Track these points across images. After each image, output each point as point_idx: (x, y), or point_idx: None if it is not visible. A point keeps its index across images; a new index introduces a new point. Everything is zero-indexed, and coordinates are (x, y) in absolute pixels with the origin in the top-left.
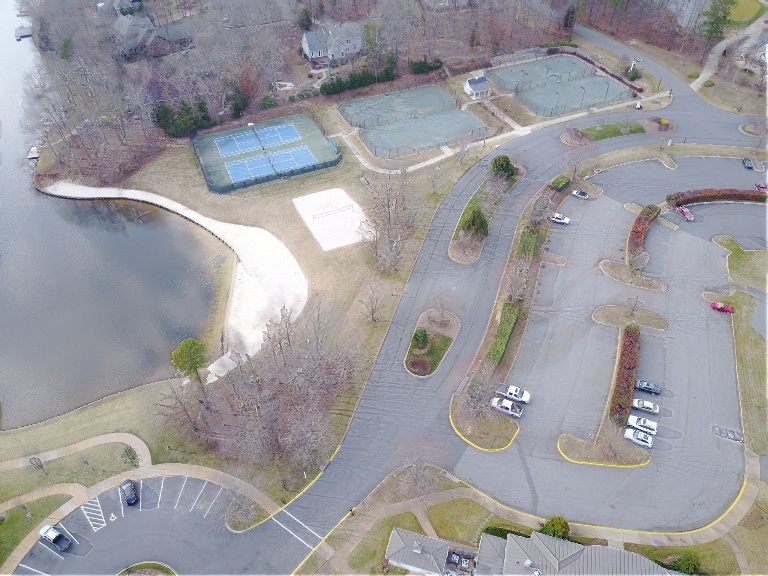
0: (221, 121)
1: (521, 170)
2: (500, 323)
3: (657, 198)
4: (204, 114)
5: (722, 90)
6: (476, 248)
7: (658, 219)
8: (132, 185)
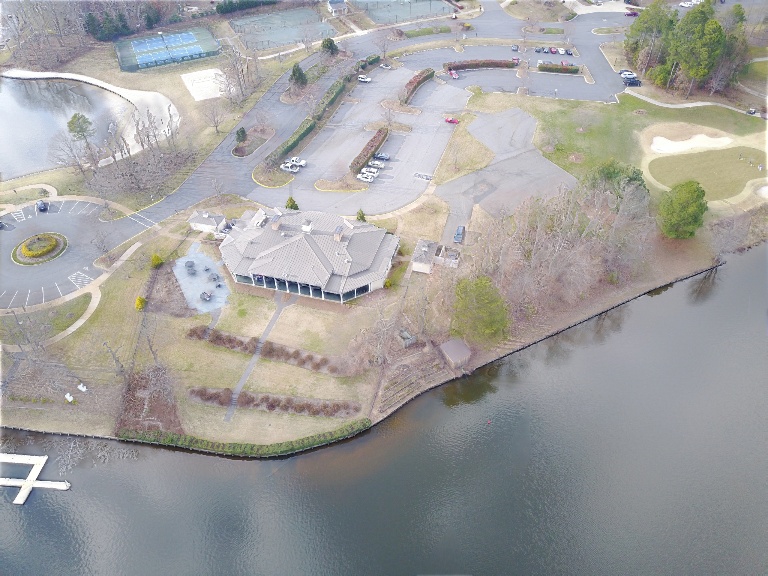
0: (138, 31)
1: (349, 54)
2: (298, 128)
3: (439, 68)
4: (123, 23)
5: (522, 6)
6: (300, 95)
7: (433, 78)
8: (66, 70)
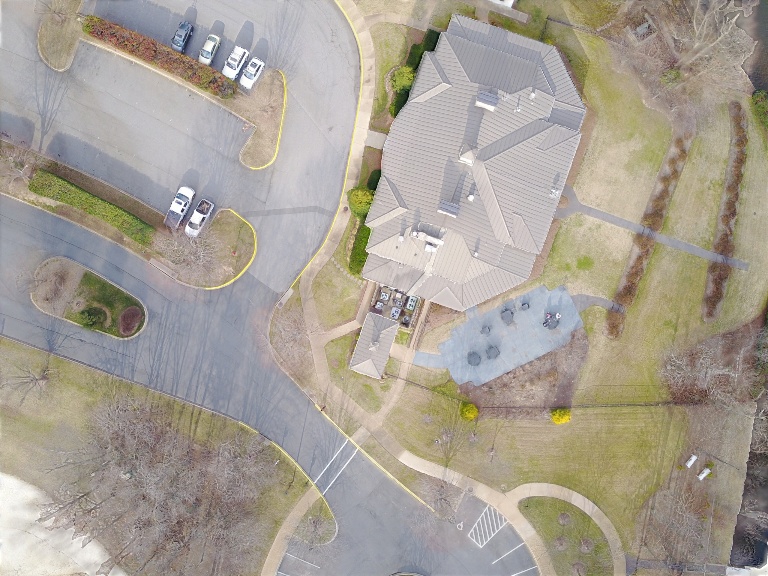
0: None
1: None
2: None
3: None
4: None
5: None
6: None
7: None
8: None
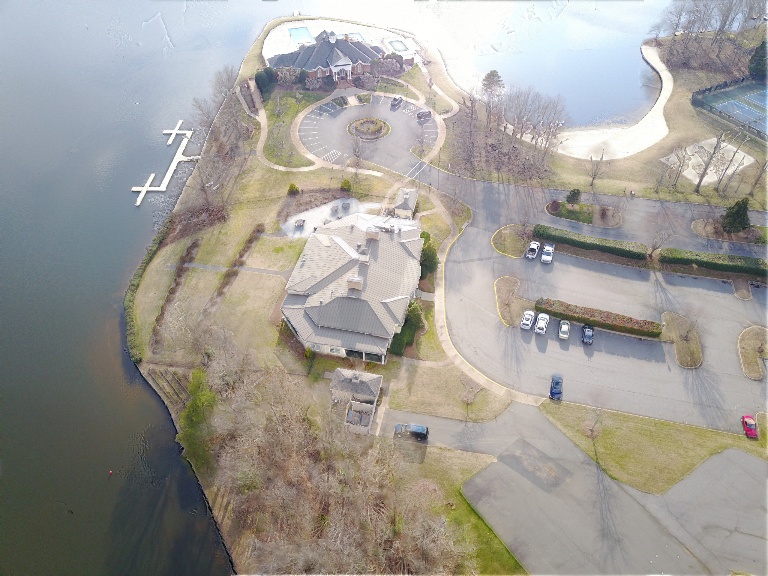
0: None
1: None
2: None
3: None
4: None
5: None
6: (719, 235)
7: None
8: (675, 72)
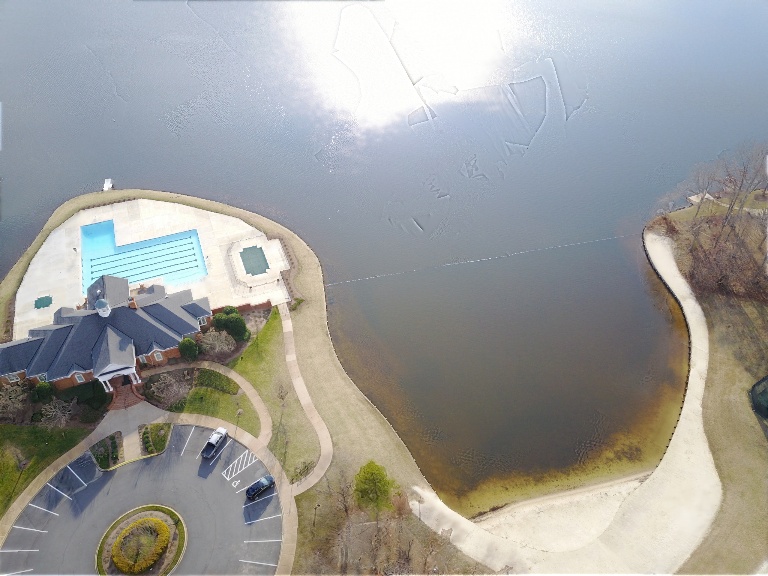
0: None
1: None
2: None
3: None
4: None
5: None
6: None
7: None
8: (707, 303)
